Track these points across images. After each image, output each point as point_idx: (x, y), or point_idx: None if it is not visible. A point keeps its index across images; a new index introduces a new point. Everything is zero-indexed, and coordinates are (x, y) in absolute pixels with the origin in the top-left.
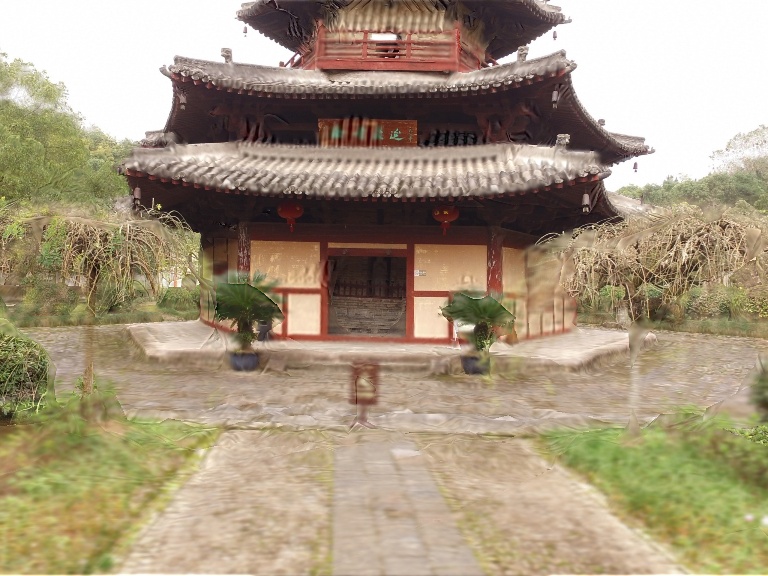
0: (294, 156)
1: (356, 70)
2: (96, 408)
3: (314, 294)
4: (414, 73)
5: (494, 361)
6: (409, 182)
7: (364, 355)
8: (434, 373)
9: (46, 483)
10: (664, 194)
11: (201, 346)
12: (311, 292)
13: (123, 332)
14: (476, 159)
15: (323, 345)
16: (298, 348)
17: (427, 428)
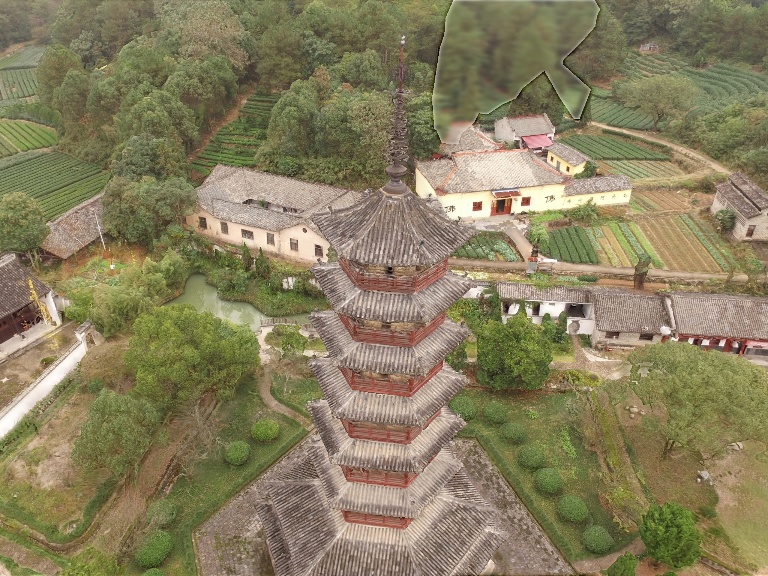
0: None
1: None
2: None
3: None
4: None
5: None
6: (471, 566)
7: None
8: None
9: None
10: (178, 107)
11: None
12: None
13: None
14: None
15: None
16: None
17: None
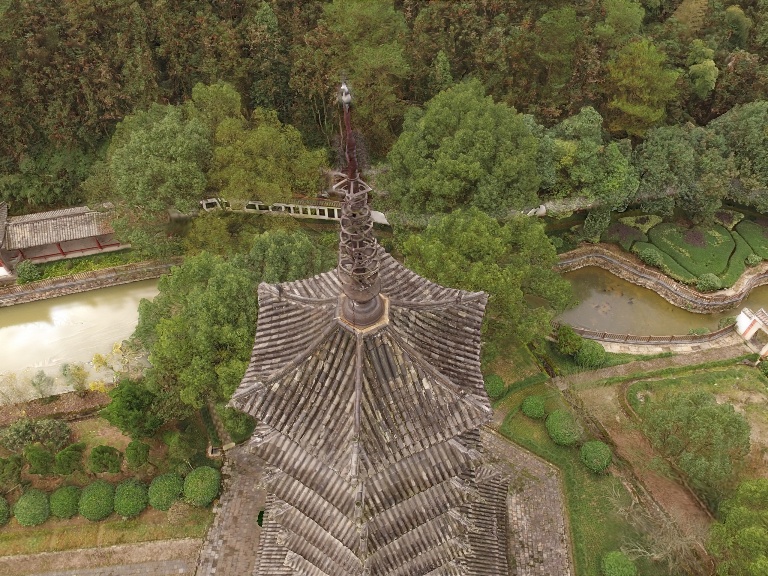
0: None
1: None
2: (188, 520)
3: None
4: None
5: None
6: None
7: None
8: None
9: (169, 525)
10: None
11: None
12: None
13: None
14: None
15: None
16: None
17: (201, 575)
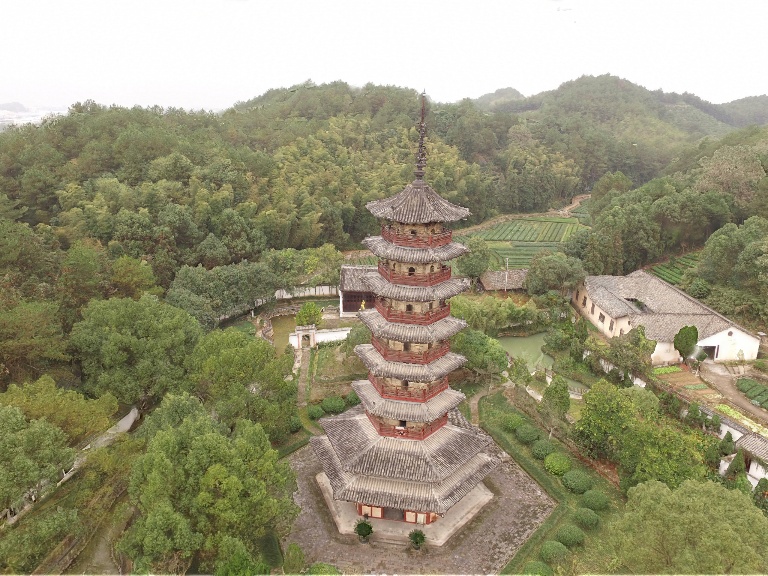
0: (374, 478)
1: (392, 437)
2: None
3: (380, 508)
4: (409, 439)
5: (422, 543)
6: (403, 500)
7: (392, 539)
8: (407, 548)
9: None
10: (640, 219)
11: (351, 524)
12: (379, 507)
13: (316, 481)
14: (423, 484)
15: (382, 527)
16: (376, 530)
17: None
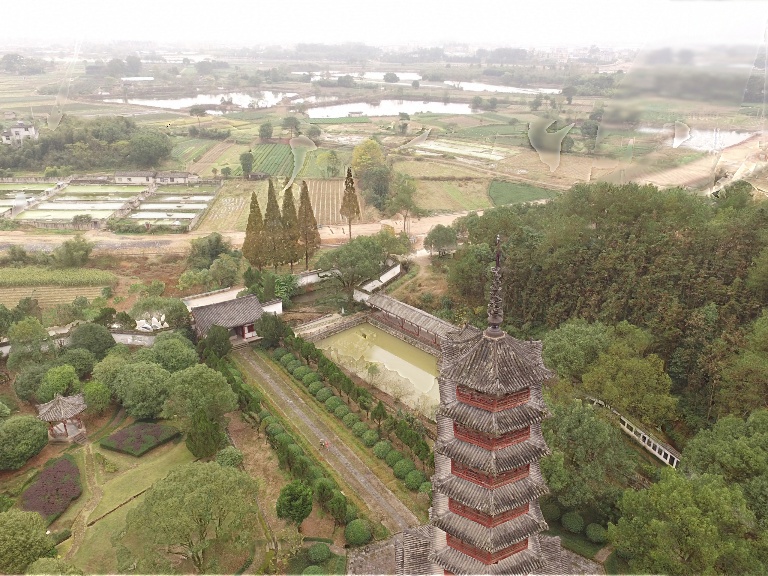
0: None
1: None
2: None
3: None
4: None
5: None
6: None
7: None
8: None
9: None
10: None
11: None
12: None
13: None
14: None
15: None
16: None
17: None
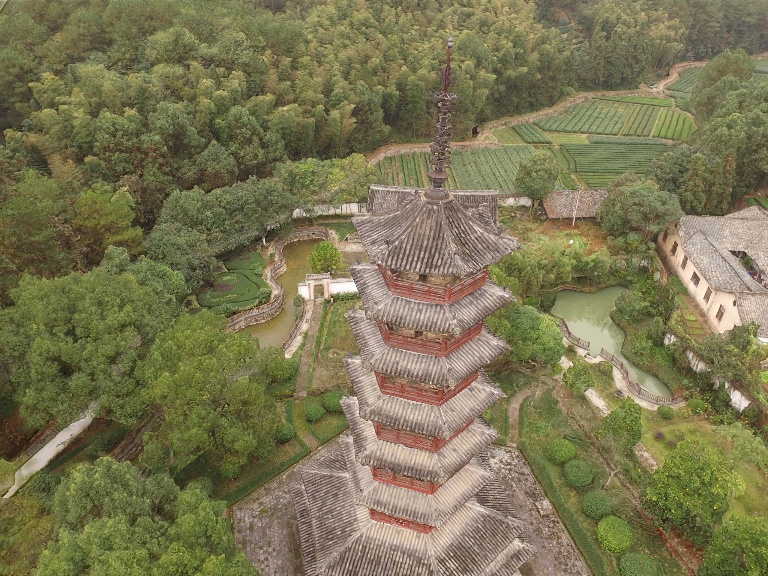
0: None
1: (387, 523)
2: None
3: None
4: None
5: None
6: None
7: None
8: None
9: None
10: (765, 133)
11: None
12: None
13: None
14: None
15: None
16: None
17: None
